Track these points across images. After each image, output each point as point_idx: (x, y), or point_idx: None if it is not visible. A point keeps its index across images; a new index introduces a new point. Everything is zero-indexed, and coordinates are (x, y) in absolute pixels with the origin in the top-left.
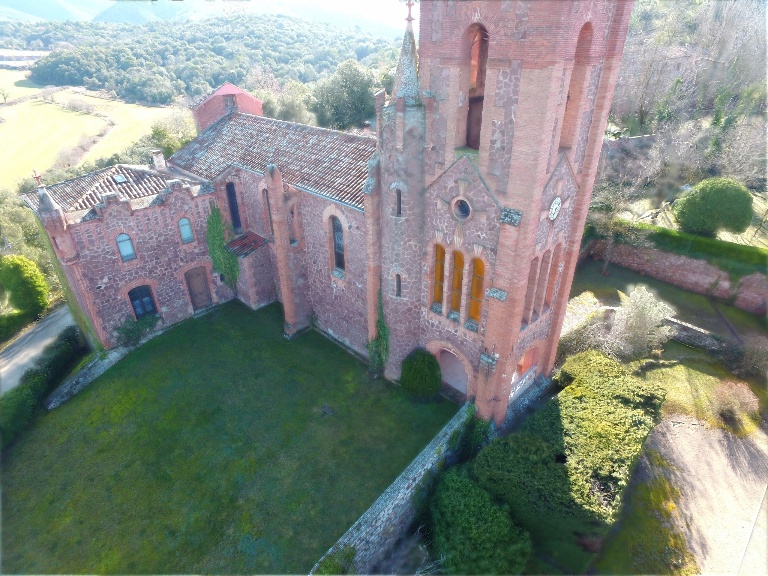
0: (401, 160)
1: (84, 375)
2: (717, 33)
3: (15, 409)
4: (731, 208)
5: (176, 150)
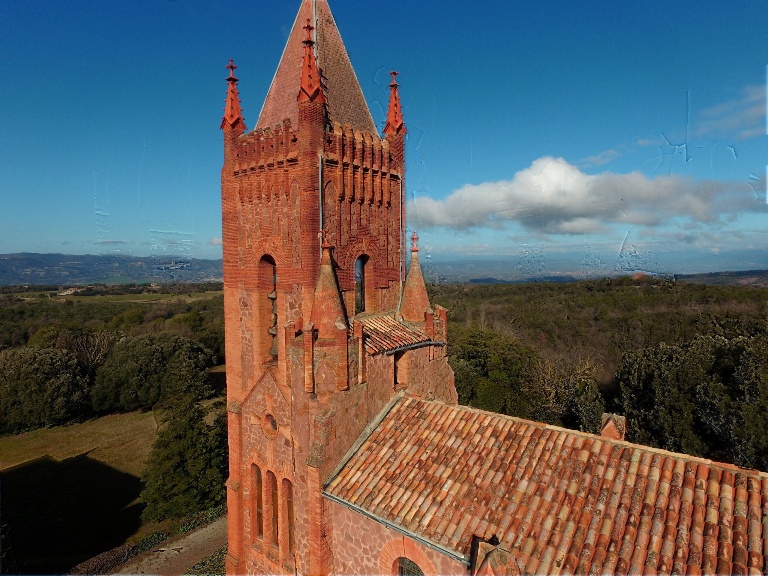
0: None
1: None
2: None
3: None
4: None
5: None
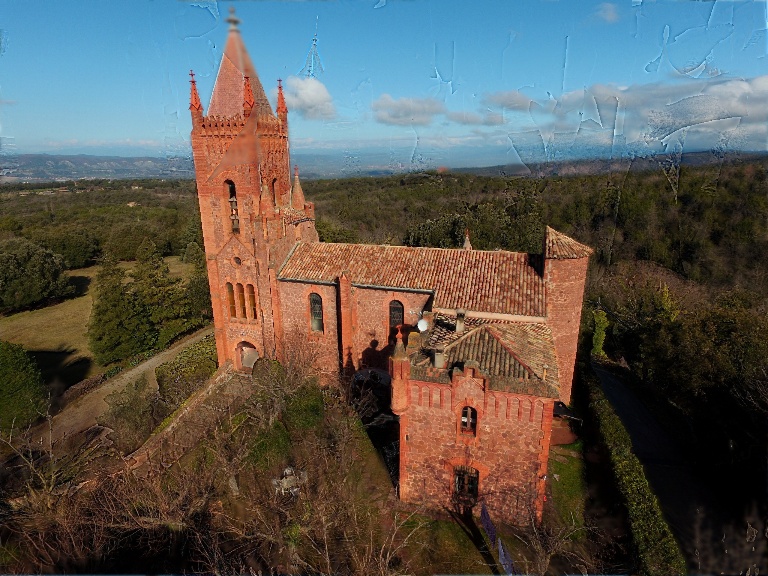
0: None
1: None
2: None
3: None
4: None
5: None
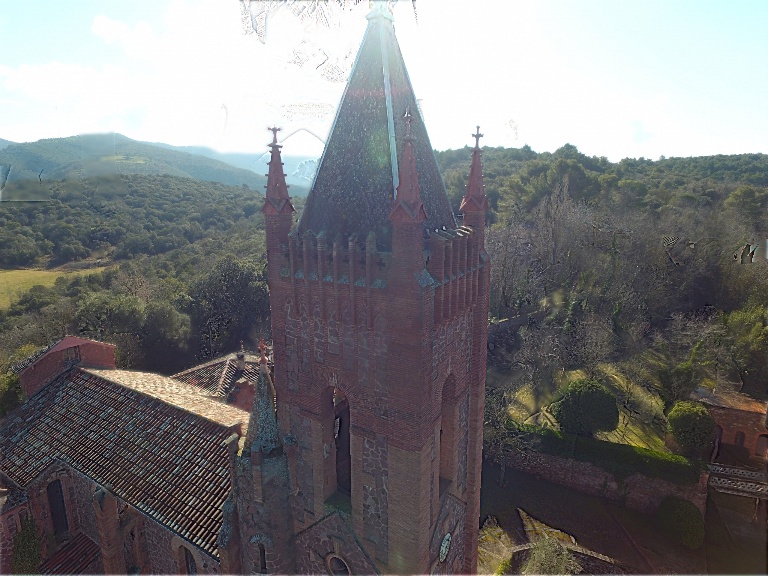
0: (262, 512)
1: None
2: (550, 229)
3: None
4: (600, 411)
5: (0, 395)
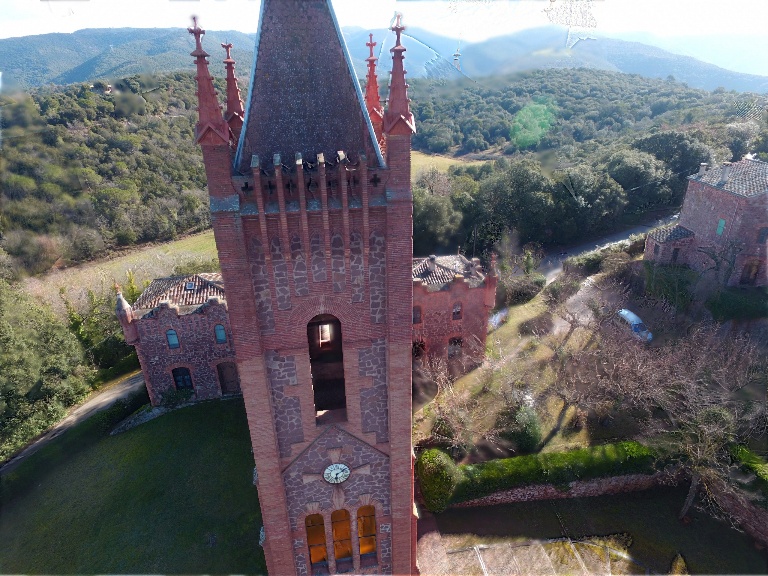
0: None
1: (135, 419)
2: None
3: (89, 428)
4: None
5: None
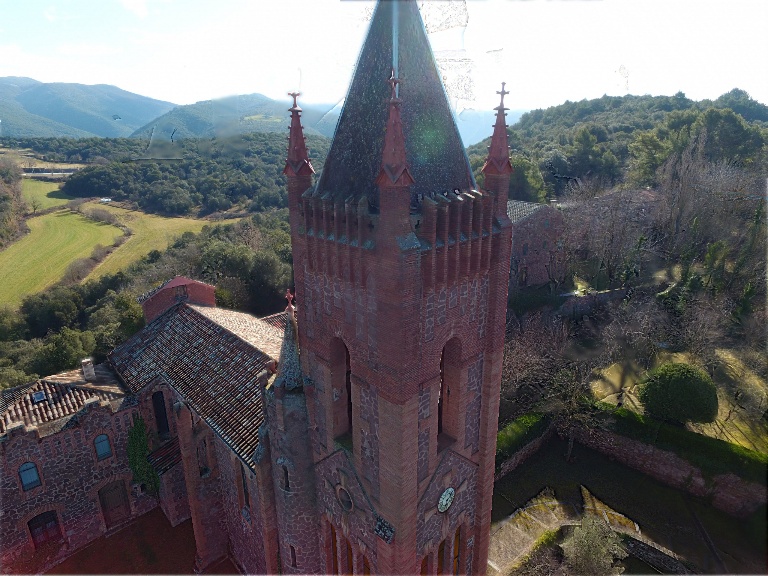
0: (285, 439)
1: None
2: (676, 193)
3: None
4: (692, 400)
5: (137, 320)
